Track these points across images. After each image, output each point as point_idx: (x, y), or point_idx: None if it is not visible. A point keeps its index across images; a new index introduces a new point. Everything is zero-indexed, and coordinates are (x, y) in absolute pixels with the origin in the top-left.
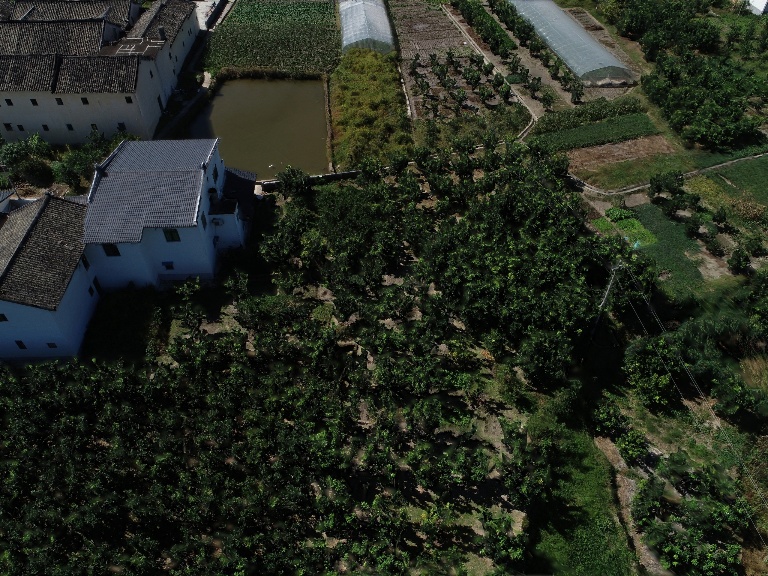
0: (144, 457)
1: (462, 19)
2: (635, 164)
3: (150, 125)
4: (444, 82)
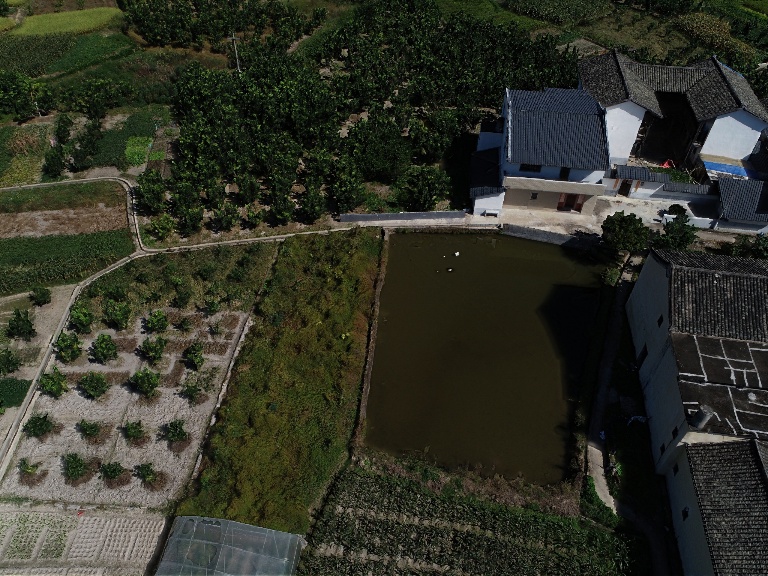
0: None
1: None
2: (52, 200)
3: None
4: None
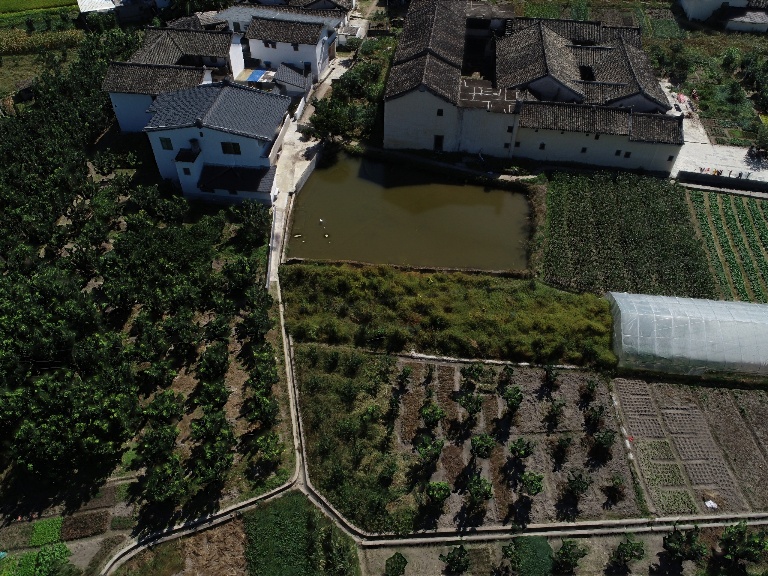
0: (4, 149)
1: None
2: None
3: (397, 139)
4: None
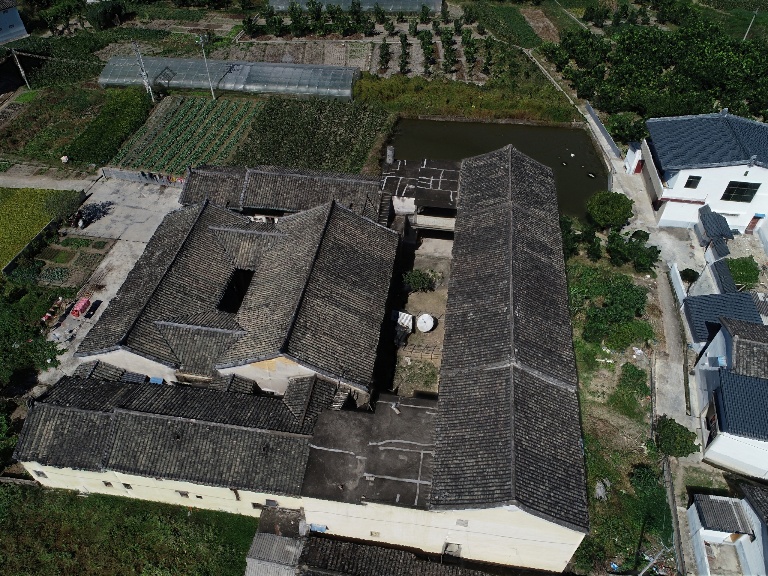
0: None
1: (285, 38)
2: None
3: None
4: (447, 55)
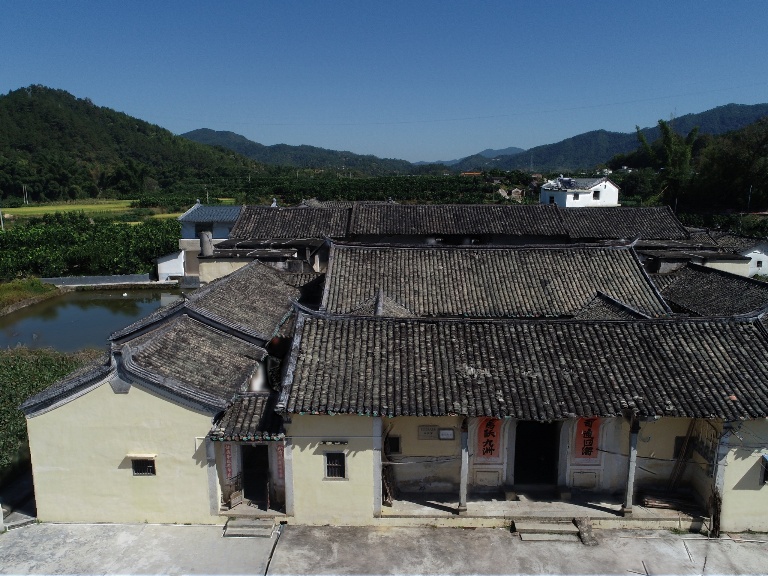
0: None
1: None
2: None
3: None
4: None
